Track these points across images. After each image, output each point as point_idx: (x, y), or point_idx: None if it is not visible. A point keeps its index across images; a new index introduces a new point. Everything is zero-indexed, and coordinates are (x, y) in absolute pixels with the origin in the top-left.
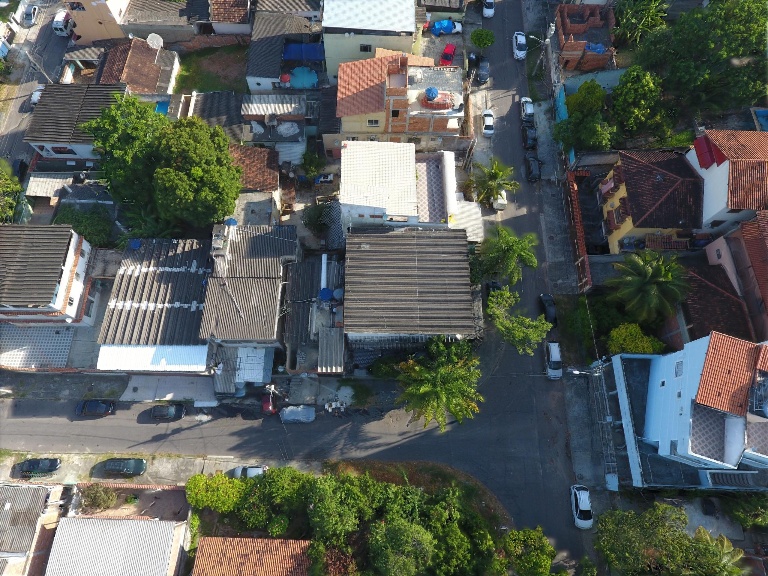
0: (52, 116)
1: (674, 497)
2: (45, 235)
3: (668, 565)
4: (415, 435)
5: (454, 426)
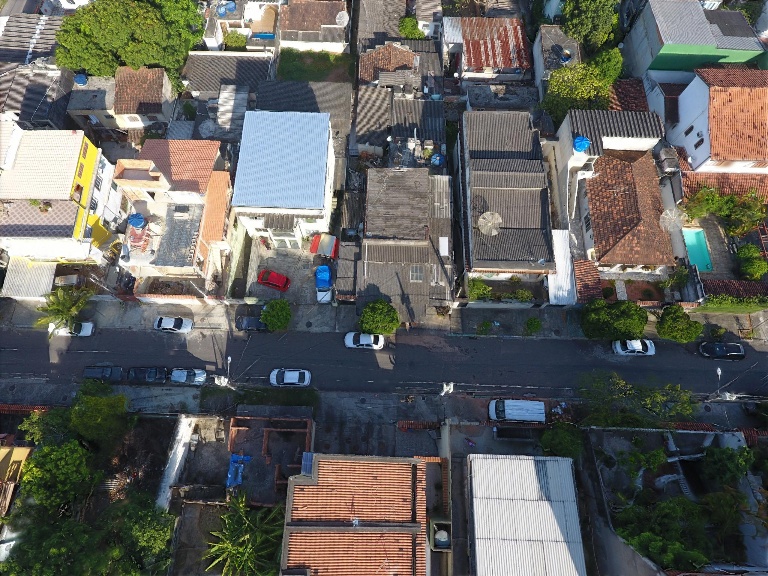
0: None
1: None
2: None
3: None
4: None
5: None
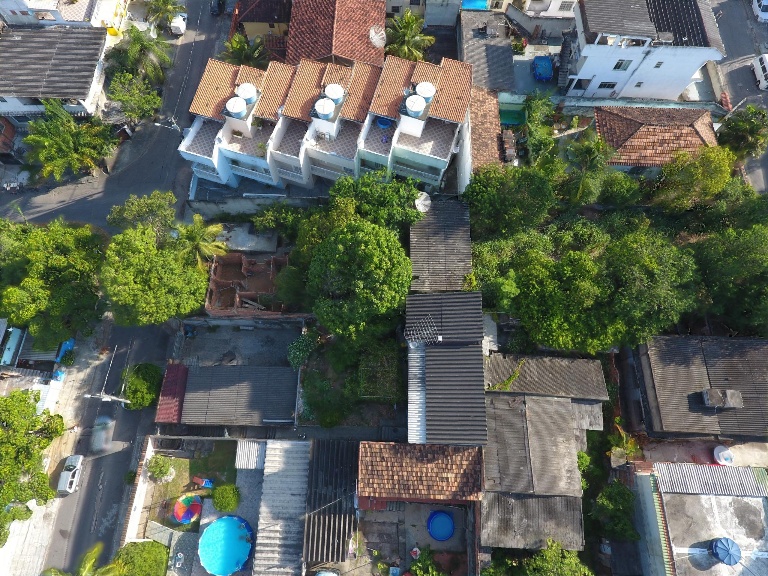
0: None
1: (228, 222)
2: None
3: (125, 215)
4: (68, 203)
5: (100, 195)
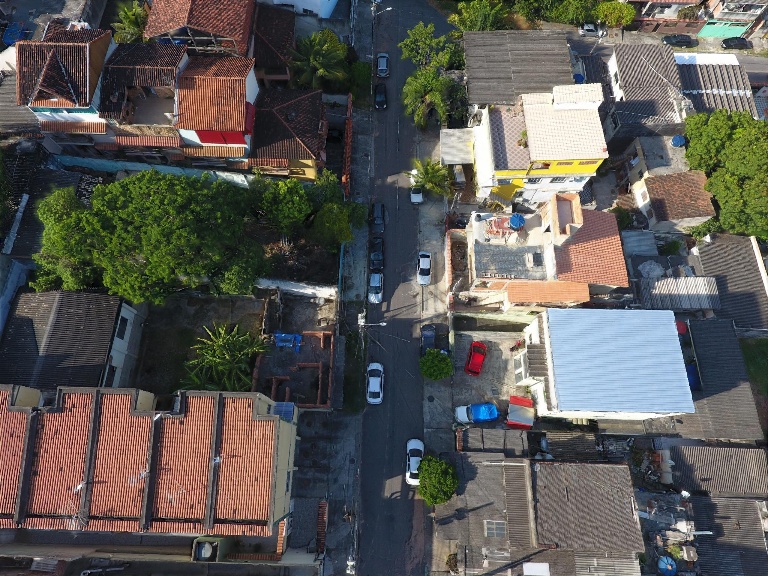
0: None
1: None
2: None
3: None
4: None
5: None
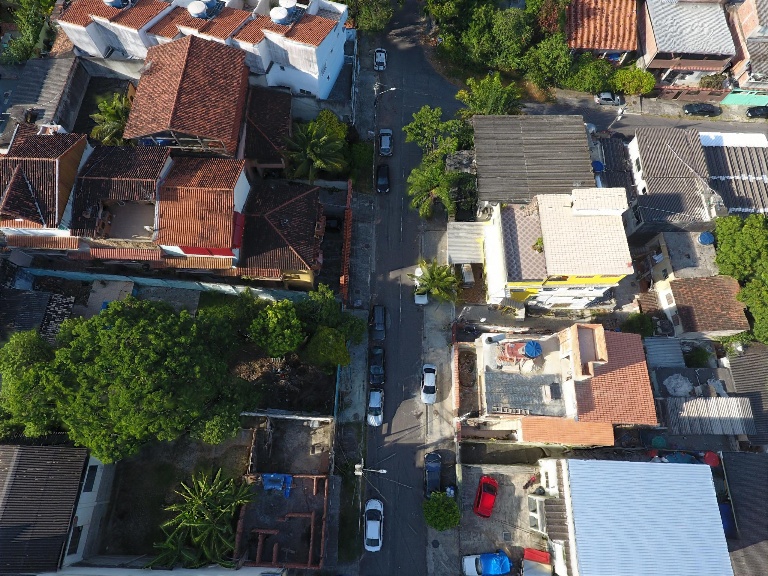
0: None
1: None
2: None
3: None
4: None
5: None
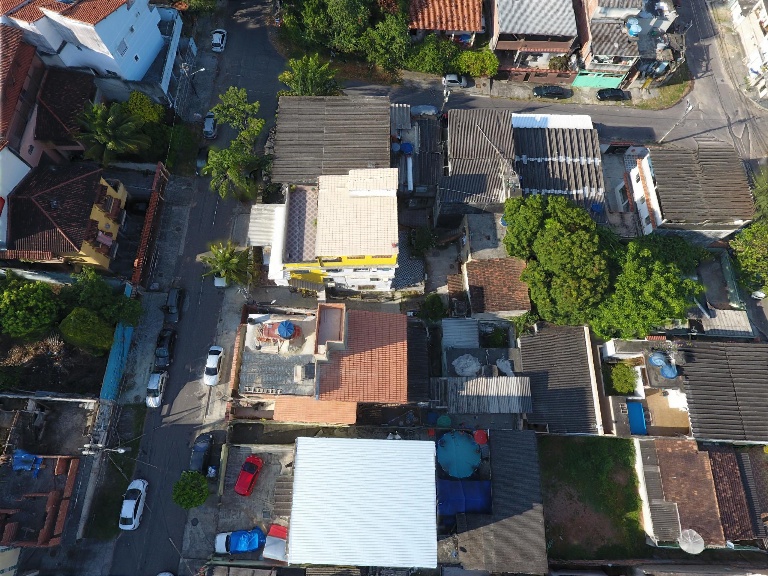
0: (766, 384)
1: None
2: (687, 209)
3: None
4: None
5: None
